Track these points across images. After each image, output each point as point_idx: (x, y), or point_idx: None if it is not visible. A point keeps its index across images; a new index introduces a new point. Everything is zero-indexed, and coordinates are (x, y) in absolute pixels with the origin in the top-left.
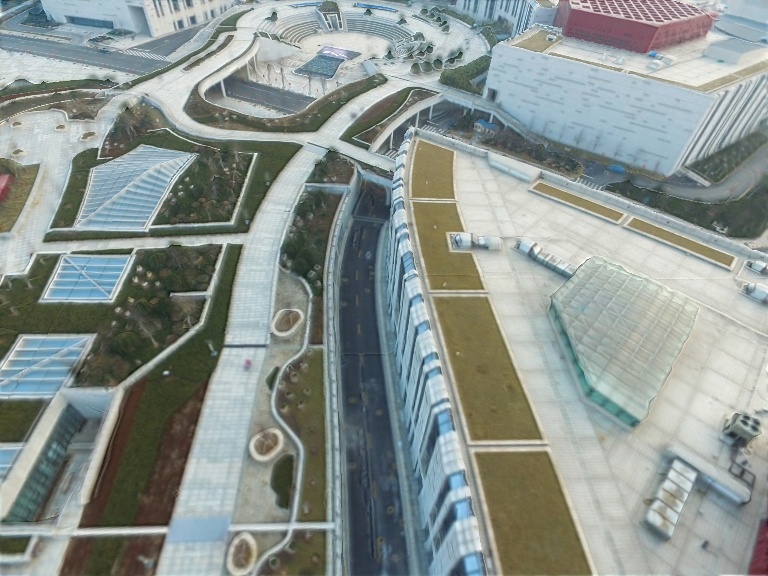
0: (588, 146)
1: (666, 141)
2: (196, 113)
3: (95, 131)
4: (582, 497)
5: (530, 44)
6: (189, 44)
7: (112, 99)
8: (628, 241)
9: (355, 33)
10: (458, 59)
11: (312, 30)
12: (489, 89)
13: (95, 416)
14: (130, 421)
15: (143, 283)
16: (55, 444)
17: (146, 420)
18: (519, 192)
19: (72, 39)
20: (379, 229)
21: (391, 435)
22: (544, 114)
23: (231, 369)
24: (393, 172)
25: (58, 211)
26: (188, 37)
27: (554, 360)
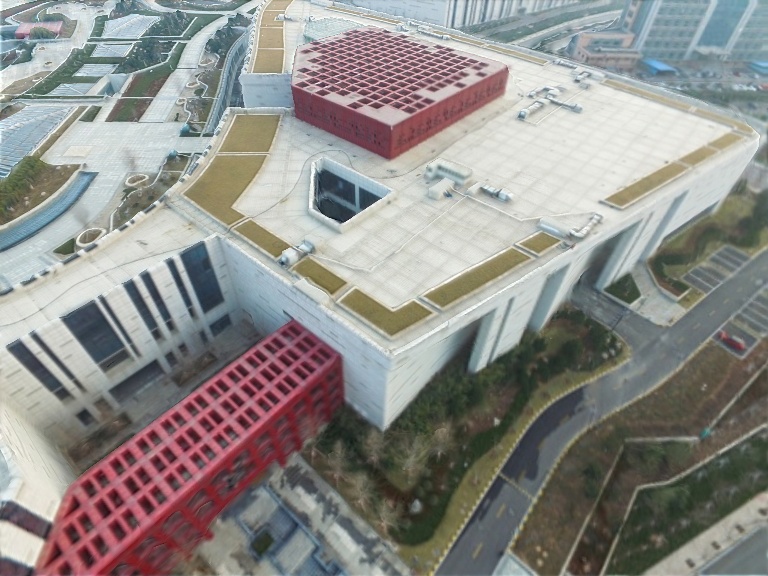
0: None
1: (436, 10)
2: (163, 3)
3: None
4: (291, 56)
5: None
6: None
7: None
8: (359, 20)
9: None
10: None
11: None
12: None
13: None
14: None
15: None
16: (106, 94)
17: None
18: (319, 9)
19: None
20: None
21: None
22: (375, 3)
23: (180, 73)
24: None
25: (92, 32)
26: None
27: (301, 39)
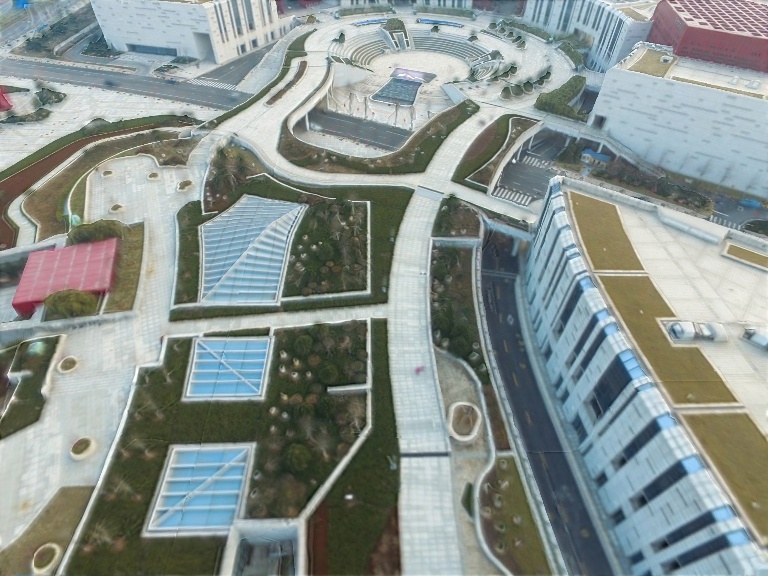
0: (714, 178)
1: None
2: (292, 154)
3: (190, 179)
4: None
5: (646, 67)
6: (256, 70)
7: (201, 141)
8: None
9: (423, 52)
10: (546, 80)
11: (379, 50)
12: (596, 116)
13: (263, 544)
14: (324, 567)
15: (293, 374)
16: None
17: (342, 565)
18: (711, 258)
19: (137, 69)
20: (513, 286)
21: (609, 566)
22: (662, 143)
23: (418, 488)
24: (525, 221)
25: (178, 282)
26: (253, 62)
27: None
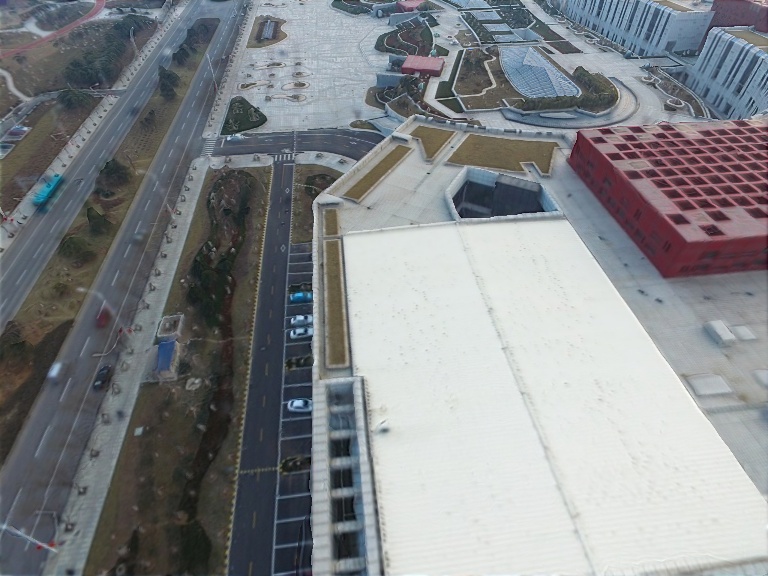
0: None
1: None
2: None
3: None
4: None
5: None
6: None
7: None
8: None
9: None
10: None
11: None
12: None
13: None
14: None
15: (508, 15)
16: None
17: None
18: None
19: None
20: None
21: None
22: None
23: None
24: None
25: (453, 5)
26: None
27: None
